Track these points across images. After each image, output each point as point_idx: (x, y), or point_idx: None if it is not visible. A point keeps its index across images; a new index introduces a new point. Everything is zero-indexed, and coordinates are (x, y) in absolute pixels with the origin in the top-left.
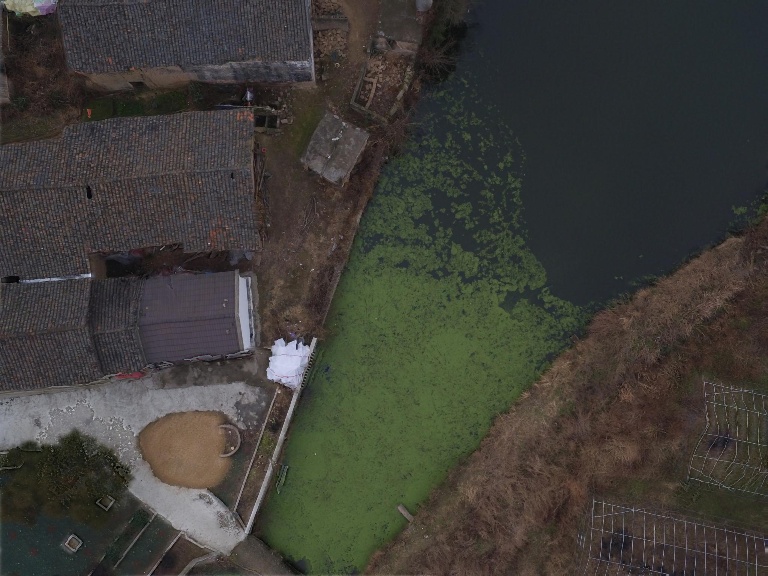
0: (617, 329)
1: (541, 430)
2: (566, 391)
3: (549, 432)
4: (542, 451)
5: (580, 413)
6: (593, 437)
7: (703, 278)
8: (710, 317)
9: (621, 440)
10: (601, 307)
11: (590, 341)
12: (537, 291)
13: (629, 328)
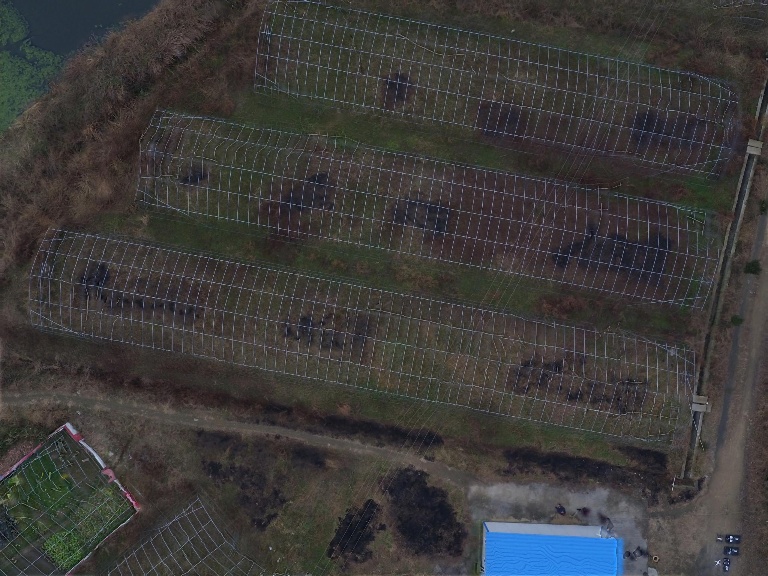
0: (85, 70)
1: (13, 170)
2: (38, 132)
3: (21, 172)
4: (15, 191)
5: (51, 153)
6: (63, 175)
7: (167, 17)
8: (180, 57)
9: (88, 175)
10: (77, 53)
11: (62, 84)
12: (19, 42)
13: (95, 67)
